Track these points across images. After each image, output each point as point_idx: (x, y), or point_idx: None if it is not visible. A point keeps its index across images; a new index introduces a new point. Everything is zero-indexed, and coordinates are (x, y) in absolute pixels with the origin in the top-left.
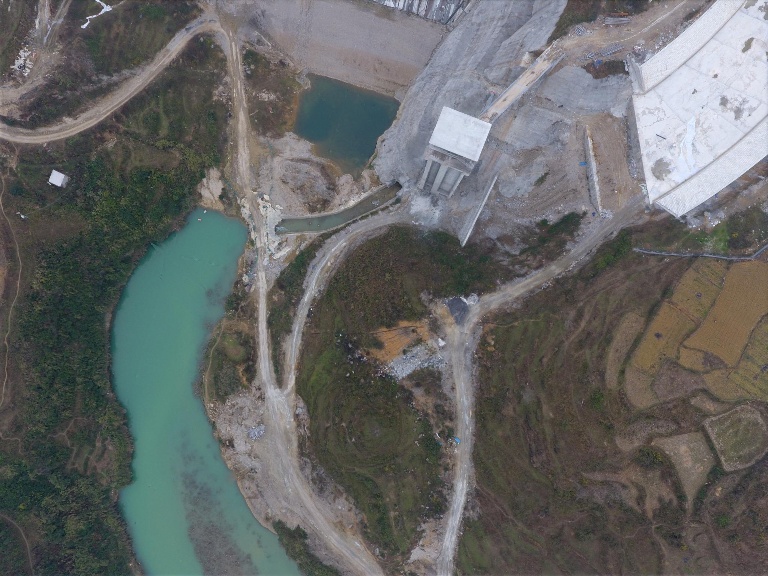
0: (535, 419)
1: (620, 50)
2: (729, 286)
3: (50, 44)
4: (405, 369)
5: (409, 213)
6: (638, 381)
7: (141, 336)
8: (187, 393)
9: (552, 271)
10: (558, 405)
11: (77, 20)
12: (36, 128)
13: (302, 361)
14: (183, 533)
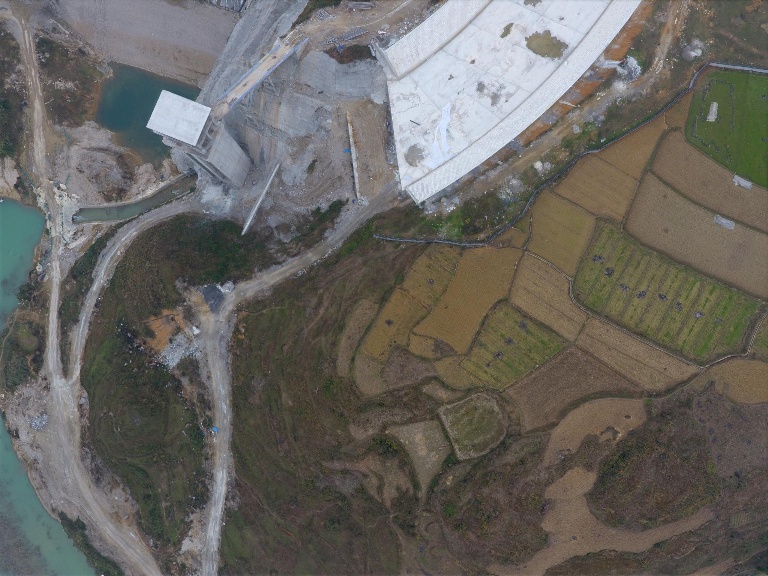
0: (276, 407)
1: (363, 35)
2: (461, 272)
3: None
4: (174, 358)
5: (200, 202)
6: (368, 368)
7: None
8: None
9: (308, 258)
10: (295, 393)
11: None
12: None
13: (85, 351)
14: None
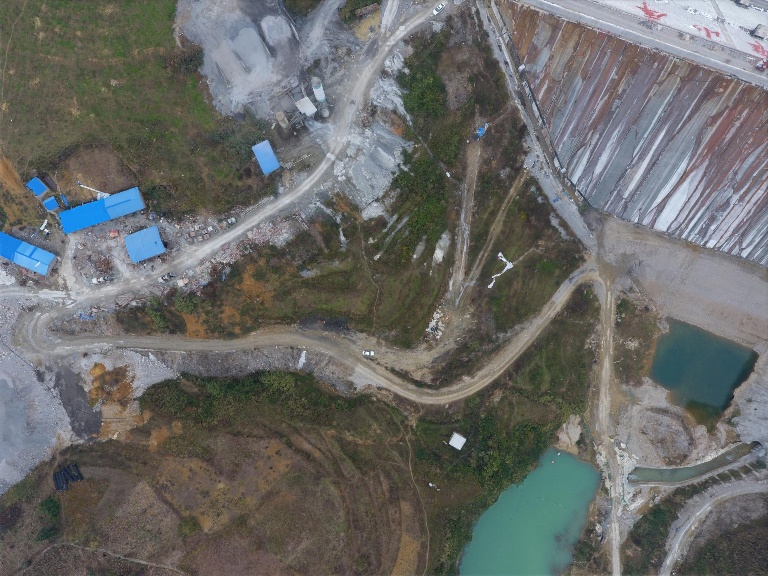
0: None
1: None
2: None
3: (462, 306)
4: None
5: None
6: None
7: (482, 571)
8: None
9: None
10: None
11: (485, 280)
12: (439, 388)
13: None
14: None
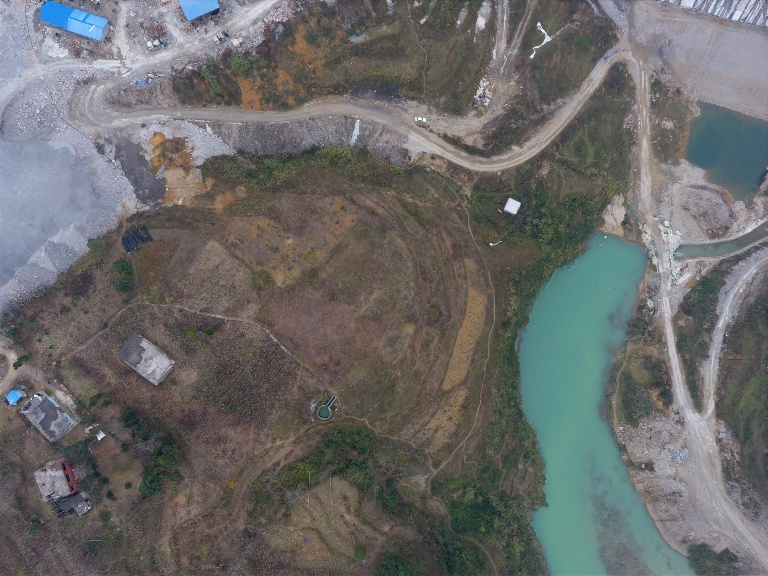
0: None
1: None
2: None
3: (507, 74)
4: None
5: None
6: None
7: (540, 359)
8: (593, 416)
9: None
10: None
11: (526, 50)
12: (491, 157)
13: (726, 387)
14: (595, 554)
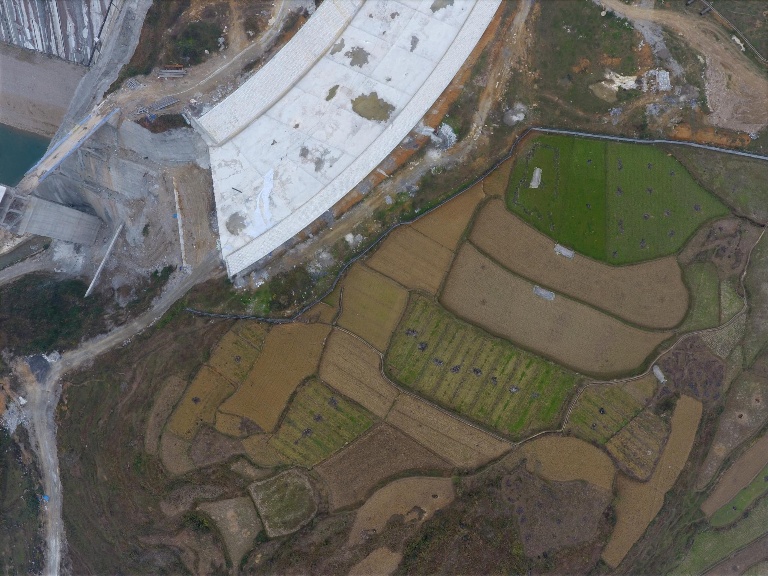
0: (93, 482)
1: (175, 104)
2: (268, 349)
3: None
4: (13, 424)
5: (52, 260)
6: (174, 447)
7: None
8: None
9: (134, 328)
10: (109, 469)
11: None
12: None
13: None
14: None
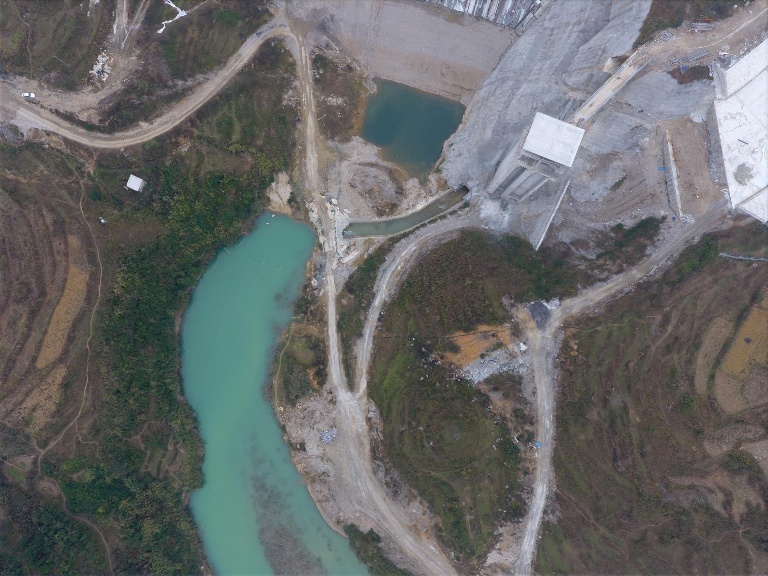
0: (621, 423)
1: (706, 56)
2: None
3: (128, 49)
4: (482, 373)
5: (479, 217)
6: (728, 386)
7: (209, 340)
8: (256, 397)
9: (633, 276)
10: (645, 410)
11: (153, 25)
12: (113, 133)
13: (374, 365)
14: (253, 536)
